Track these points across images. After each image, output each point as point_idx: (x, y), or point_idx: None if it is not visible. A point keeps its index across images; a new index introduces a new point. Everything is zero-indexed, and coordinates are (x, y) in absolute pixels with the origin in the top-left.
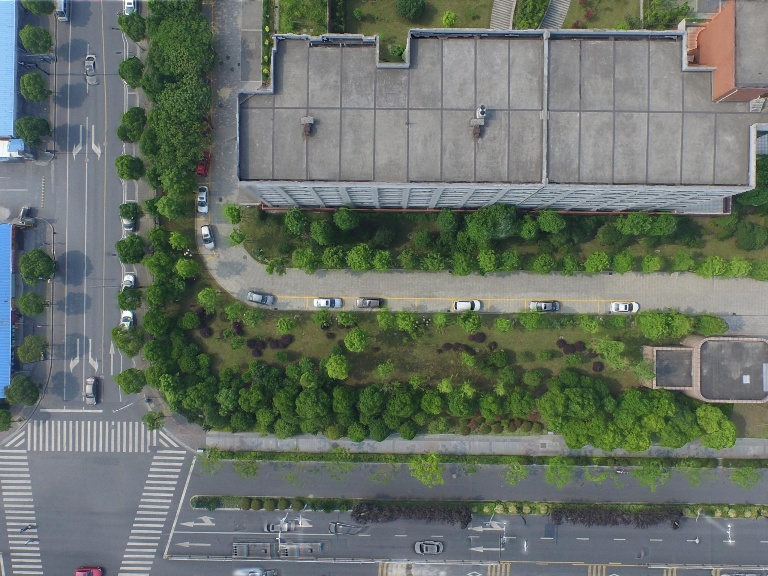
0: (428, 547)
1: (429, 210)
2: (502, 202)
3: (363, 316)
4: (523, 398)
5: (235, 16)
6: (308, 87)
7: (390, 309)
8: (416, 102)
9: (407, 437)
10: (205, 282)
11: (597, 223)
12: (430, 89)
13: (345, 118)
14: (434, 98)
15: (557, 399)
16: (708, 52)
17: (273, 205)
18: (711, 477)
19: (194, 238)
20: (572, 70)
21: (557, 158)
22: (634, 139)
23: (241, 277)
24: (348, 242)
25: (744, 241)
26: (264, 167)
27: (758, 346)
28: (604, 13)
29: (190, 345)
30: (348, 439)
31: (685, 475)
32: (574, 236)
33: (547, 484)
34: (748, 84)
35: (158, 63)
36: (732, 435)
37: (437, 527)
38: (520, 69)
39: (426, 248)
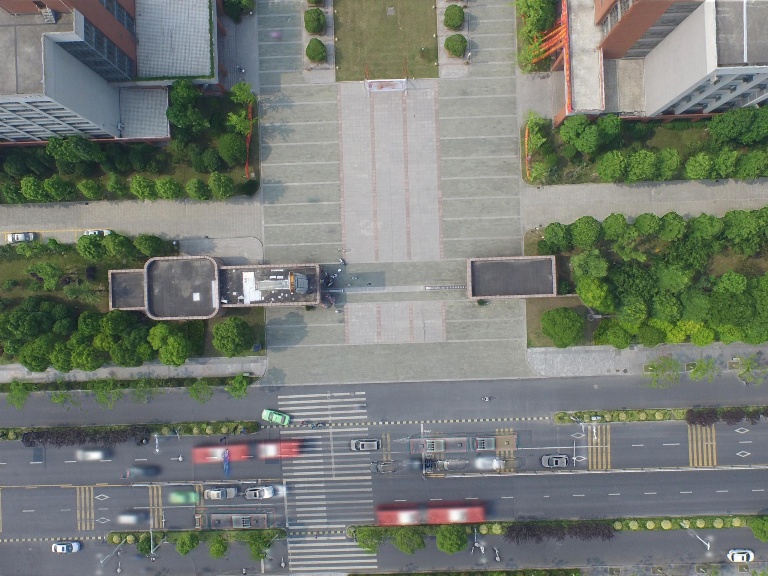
0: None
1: None
2: None
3: None
4: None
5: None
6: None
7: None
8: None
9: None
10: None
11: None
12: None
13: None
14: None
15: None
16: None
17: None
18: None
19: None
20: None
21: None
22: None
23: None
24: None
25: (193, 164)
26: None
27: (207, 264)
28: None
29: None
30: None
31: (167, 396)
32: (30, 166)
33: (34, 410)
34: None
35: None
36: (177, 350)
37: None
38: None
39: None
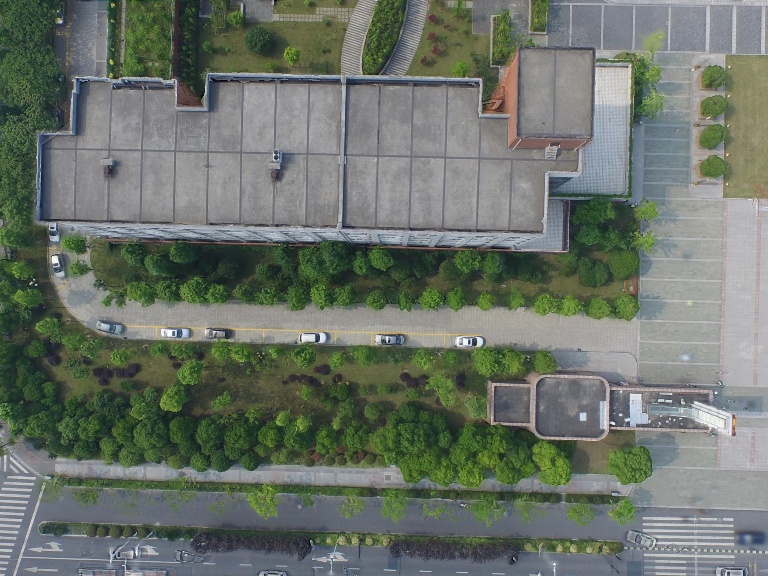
0: None
1: (269, 244)
2: (329, 239)
3: (211, 346)
4: (357, 432)
5: (90, 47)
6: (110, 129)
7: (238, 340)
8: (216, 145)
9: (247, 468)
10: (55, 310)
11: (439, 258)
12: (230, 132)
13: (146, 160)
14: (234, 141)
15: (388, 434)
16: (507, 98)
17: (114, 237)
18: (554, 512)
19: (46, 267)
20: (371, 115)
21: (354, 202)
22: (431, 184)
23: (92, 306)
24: (191, 274)
25: (584, 278)
26: (66, 207)
27: (595, 384)
28: (454, 48)
29: (36, 373)
30: (192, 469)
31: (529, 509)
32: (415, 271)
33: None
34: (532, 134)
35: (1, 95)
36: (565, 472)
37: (279, 557)
38: (319, 113)
39: (268, 281)
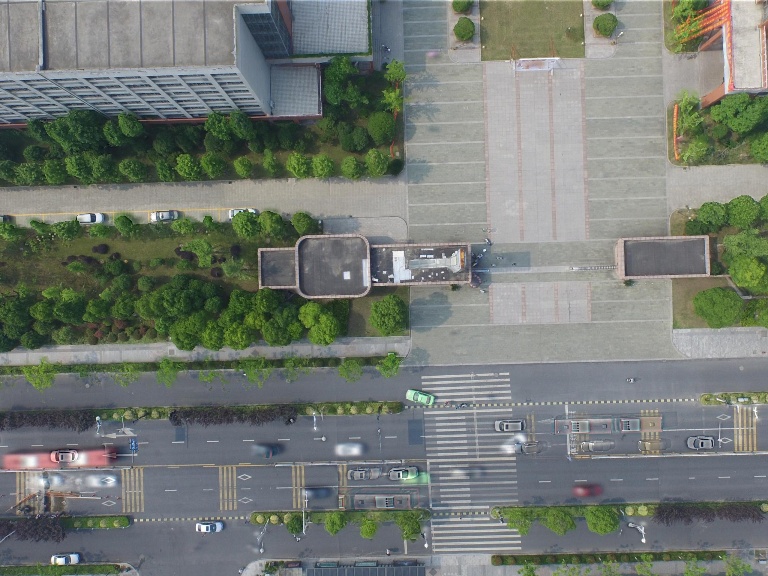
0: (63, 455)
1: None
2: (74, 107)
3: None
4: None
5: None
6: None
7: (18, 226)
8: None
9: (26, 346)
10: None
11: (203, 131)
12: None
13: None
14: None
15: (150, 299)
16: None
17: None
18: (334, 376)
19: None
20: None
21: (56, 47)
22: (128, 26)
23: None
24: None
25: (343, 142)
26: None
27: (357, 243)
28: None
29: None
30: None
31: (310, 375)
32: (178, 144)
33: (177, 389)
34: None
35: None
36: (329, 329)
37: (66, 434)
38: None
39: (36, 162)
